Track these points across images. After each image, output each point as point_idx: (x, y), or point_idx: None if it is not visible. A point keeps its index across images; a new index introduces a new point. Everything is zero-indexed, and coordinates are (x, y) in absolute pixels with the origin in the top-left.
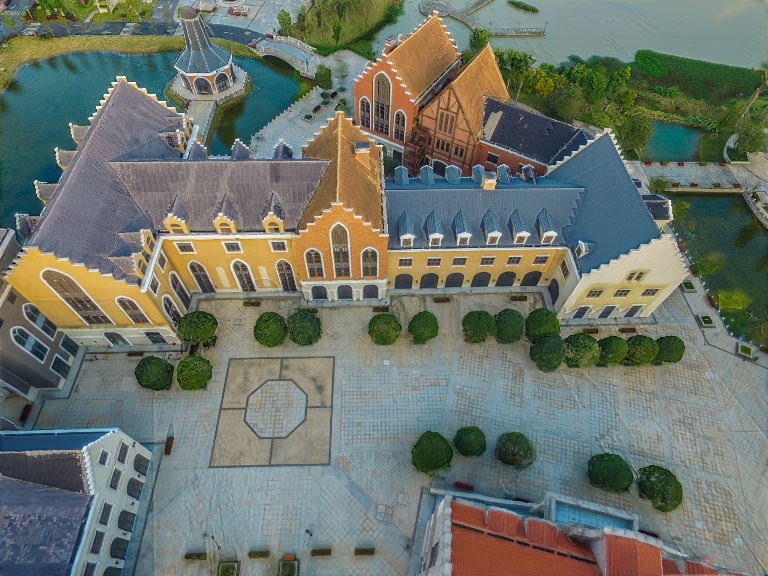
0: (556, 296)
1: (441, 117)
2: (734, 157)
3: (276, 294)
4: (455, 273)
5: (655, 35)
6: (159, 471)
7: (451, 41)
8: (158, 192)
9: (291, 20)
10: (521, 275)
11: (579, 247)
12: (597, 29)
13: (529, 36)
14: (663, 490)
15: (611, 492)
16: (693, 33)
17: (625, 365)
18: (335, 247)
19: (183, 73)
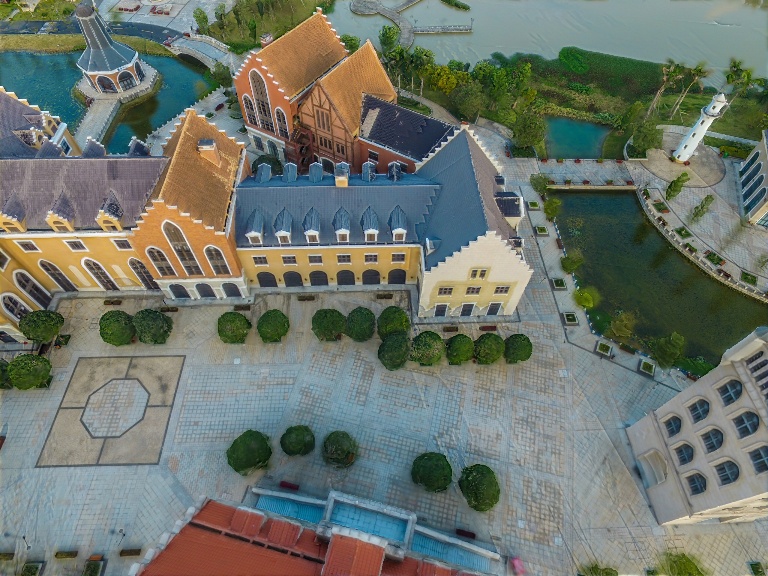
0: (418, 294)
1: (317, 114)
2: (632, 154)
3: (140, 293)
4: (316, 271)
5: (583, 32)
6: None
7: (338, 38)
8: None
9: (212, 18)
10: (385, 273)
11: (426, 244)
12: (526, 26)
13: (456, 33)
14: (476, 489)
15: (429, 491)
16: (622, 30)
17: (479, 363)
18: (175, 245)
19: (84, 71)
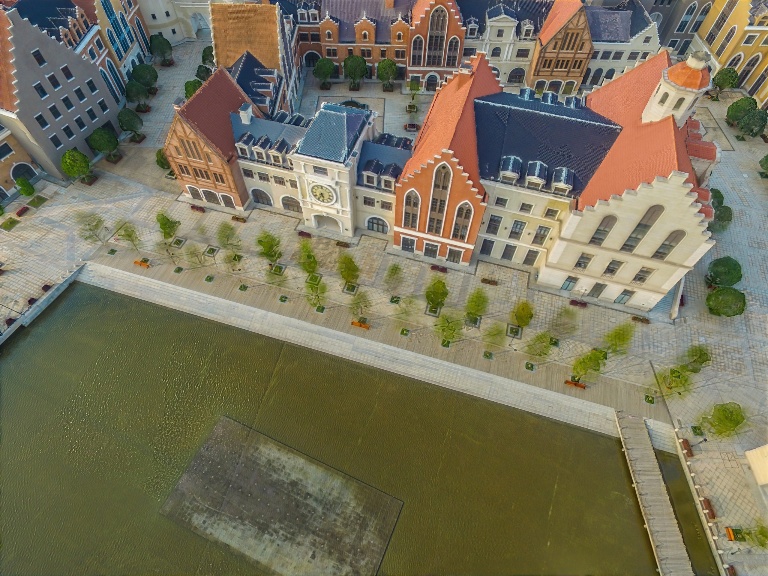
0: None
1: None
2: None
3: None
4: None
5: None
6: None
7: None
8: None
9: None
10: None
11: None
12: None
13: None
14: (728, 288)
15: None
16: None
17: None
18: None
19: None
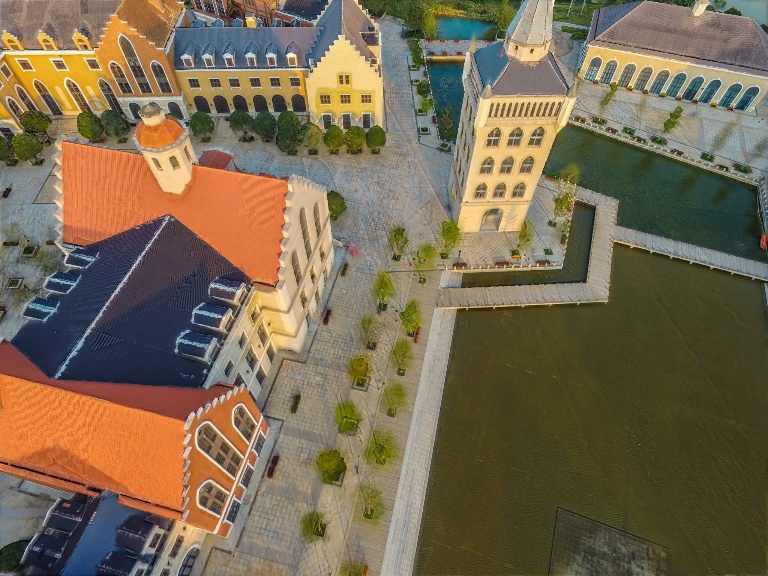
0: None
1: None
2: (500, 36)
3: None
4: (237, 96)
5: None
6: None
7: None
8: (1, 20)
9: None
10: (289, 99)
11: None
12: None
13: None
14: None
15: None
16: None
17: (351, 154)
18: (129, 60)
19: None
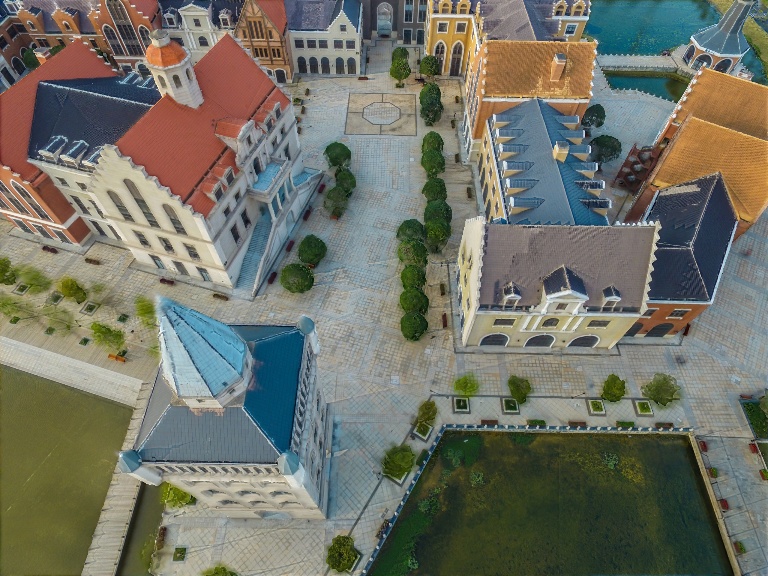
0: None
1: None
2: None
3: None
4: None
5: None
6: (350, 78)
7: None
8: None
9: None
10: None
11: None
12: None
13: None
14: None
15: None
16: None
17: None
18: None
19: None
